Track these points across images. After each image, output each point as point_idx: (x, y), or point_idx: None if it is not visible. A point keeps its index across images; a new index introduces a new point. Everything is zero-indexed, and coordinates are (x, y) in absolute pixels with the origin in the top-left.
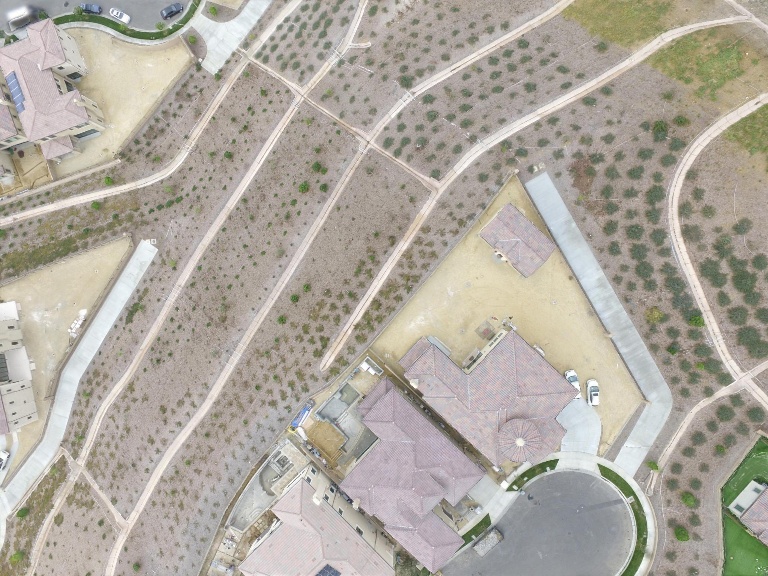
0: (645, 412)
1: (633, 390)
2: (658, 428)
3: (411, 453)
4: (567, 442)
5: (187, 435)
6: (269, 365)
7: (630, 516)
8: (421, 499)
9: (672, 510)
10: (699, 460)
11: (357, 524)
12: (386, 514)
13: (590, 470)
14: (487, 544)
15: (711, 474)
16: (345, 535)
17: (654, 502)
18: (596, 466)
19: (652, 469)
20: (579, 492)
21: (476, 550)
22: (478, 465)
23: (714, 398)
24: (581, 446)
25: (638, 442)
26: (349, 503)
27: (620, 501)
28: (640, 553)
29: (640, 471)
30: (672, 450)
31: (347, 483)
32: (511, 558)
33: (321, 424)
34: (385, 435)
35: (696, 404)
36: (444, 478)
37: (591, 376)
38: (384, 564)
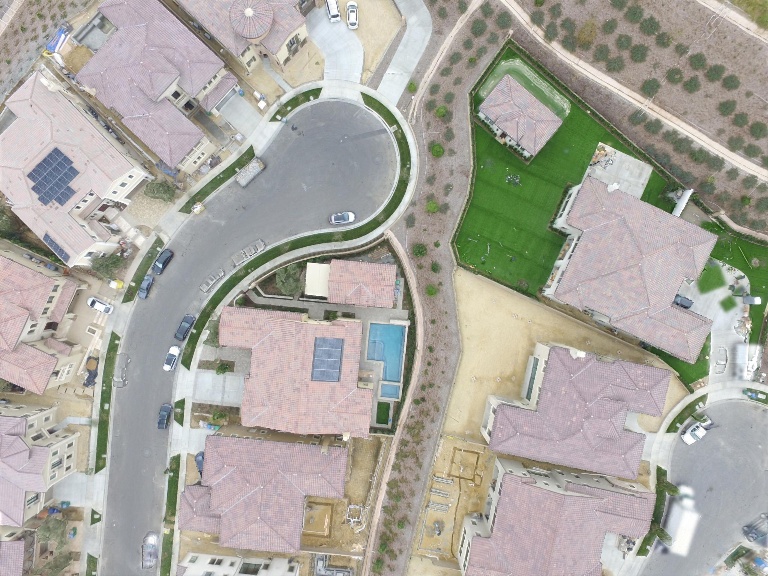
0: (406, 37)
1: (393, 14)
2: (419, 53)
3: (143, 33)
4: (330, 70)
5: None
6: (37, 9)
7: (394, 146)
8: (149, 73)
9: (431, 132)
10: (454, 76)
11: (103, 133)
12: (122, 103)
13: (354, 99)
14: (248, 173)
15: (463, 84)
16: (80, 126)
17: (416, 129)
18: (359, 94)
19: (413, 95)
20: (342, 122)
21: (238, 180)
22: (228, 73)
23: (469, 14)
24: (344, 74)
25: (400, 68)
26: (106, 129)
27: (384, 131)
28: (404, 183)
29: (402, 98)
30: (432, 75)
31: (82, 73)
32: (275, 191)
33: (78, 49)
34: (121, 21)
35: (454, 25)
36: (179, 63)
37: (352, 0)
38: (122, 159)
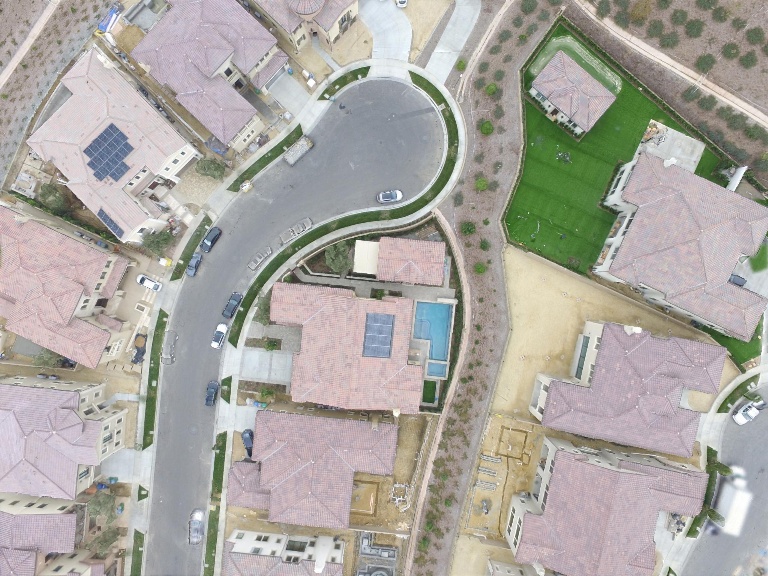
0: (454, 15)
1: None
2: (467, 31)
3: (198, 10)
4: (378, 48)
5: (8, 76)
6: None
7: (441, 125)
8: (205, 49)
9: (480, 110)
10: (504, 53)
11: None
12: (176, 80)
13: (401, 78)
14: (297, 151)
15: (513, 62)
16: (134, 103)
17: (464, 108)
18: (407, 73)
19: (462, 73)
20: (390, 100)
21: (286, 158)
22: (279, 50)
23: None
24: (392, 52)
25: (448, 47)
26: (156, 108)
27: (431, 109)
28: (451, 162)
29: (450, 77)
30: (481, 53)
31: (137, 49)
32: (323, 169)
33: (129, 28)
34: None
35: (503, 3)
36: (233, 39)
37: None
38: (175, 135)
